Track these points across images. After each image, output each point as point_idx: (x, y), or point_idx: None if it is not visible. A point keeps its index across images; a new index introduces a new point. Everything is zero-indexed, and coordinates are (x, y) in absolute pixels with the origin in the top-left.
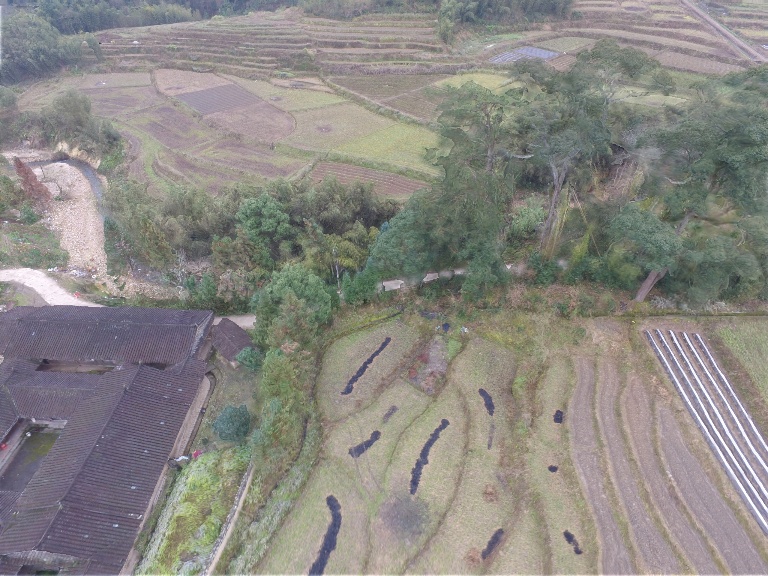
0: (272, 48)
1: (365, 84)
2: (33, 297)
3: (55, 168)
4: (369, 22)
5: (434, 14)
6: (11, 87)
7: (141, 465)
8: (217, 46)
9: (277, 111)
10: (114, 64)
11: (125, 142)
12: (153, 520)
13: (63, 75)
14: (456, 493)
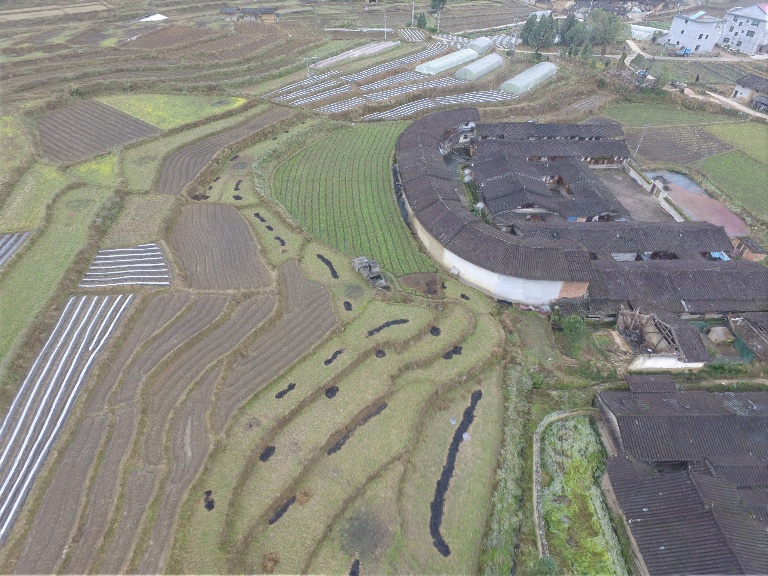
0: None
1: None
2: None
3: None
4: None
5: None
6: None
7: (678, 575)
8: None
9: None
10: None
11: None
12: (624, 542)
13: None
14: (308, 562)
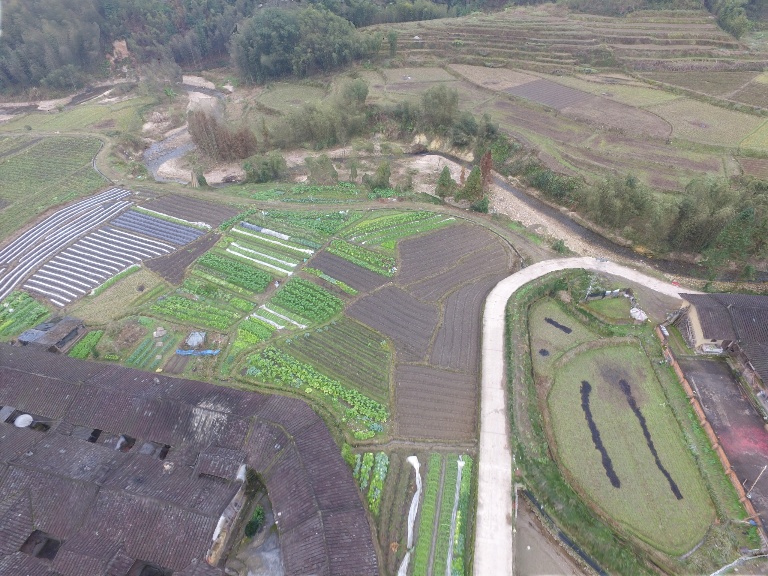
0: (561, 44)
1: (683, 80)
2: (634, 285)
3: (437, 160)
4: (644, 18)
5: (703, 10)
6: (304, 81)
7: None
8: (504, 42)
9: (625, 106)
10: (404, 59)
11: (507, 135)
12: None
13: (357, 69)
14: None
